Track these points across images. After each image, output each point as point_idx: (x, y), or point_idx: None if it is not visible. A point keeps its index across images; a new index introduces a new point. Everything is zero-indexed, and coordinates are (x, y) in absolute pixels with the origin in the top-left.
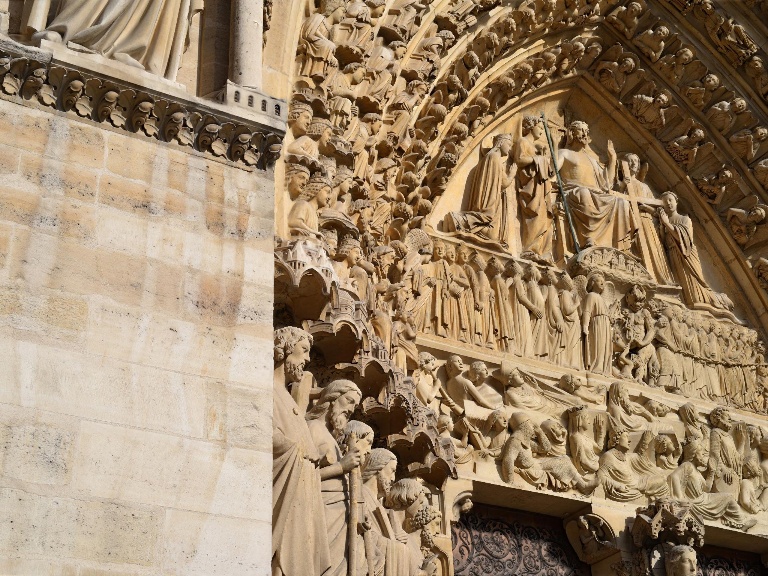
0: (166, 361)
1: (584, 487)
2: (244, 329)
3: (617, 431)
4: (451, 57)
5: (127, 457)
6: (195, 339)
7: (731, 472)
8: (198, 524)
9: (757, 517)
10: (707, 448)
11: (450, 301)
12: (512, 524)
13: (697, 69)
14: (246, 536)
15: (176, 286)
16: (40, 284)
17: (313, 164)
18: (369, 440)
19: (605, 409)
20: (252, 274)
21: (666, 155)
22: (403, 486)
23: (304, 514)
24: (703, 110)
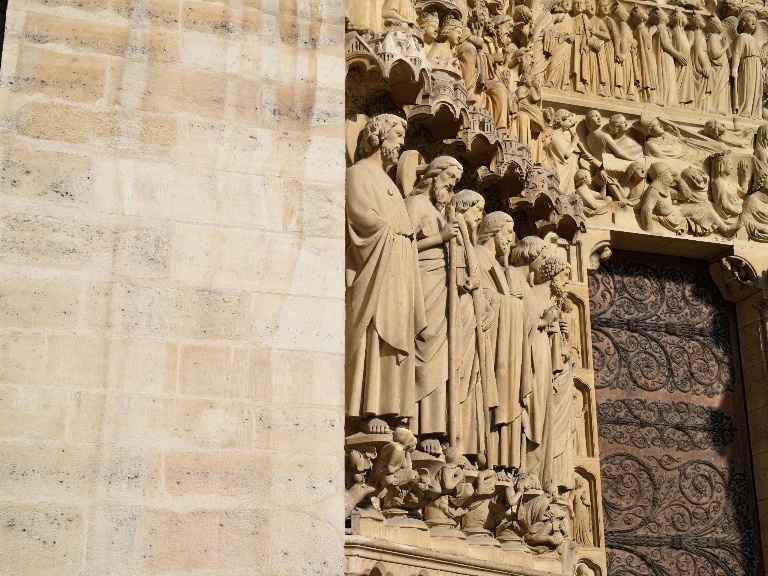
0: (248, 166)
1: (726, 230)
2: (318, 131)
3: (761, 174)
4: None
5: (216, 251)
6: (273, 144)
7: None
8: (280, 304)
9: None
10: None
11: (590, 56)
12: (655, 268)
13: None
14: (322, 312)
15: (254, 97)
16: (134, 108)
17: None
18: (479, 207)
19: (752, 152)
20: (324, 79)
21: None
22: (526, 244)
23: (397, 284)
24: None
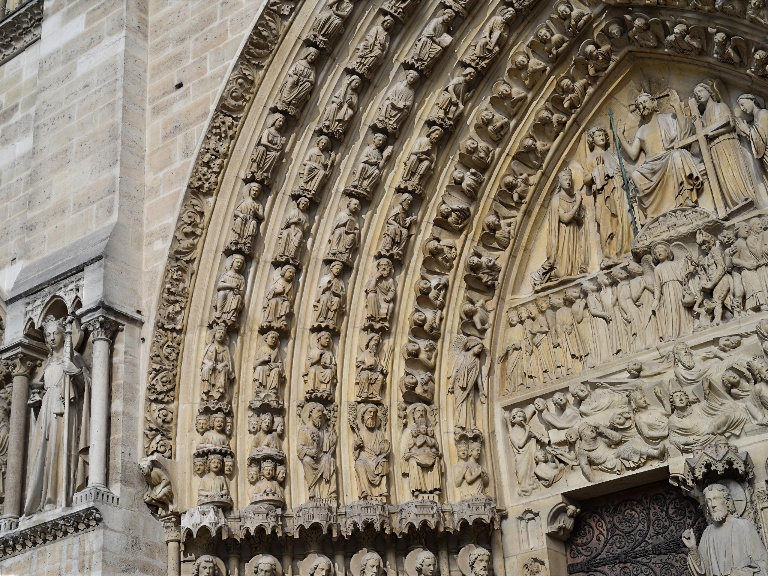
0: None
1: (657, 456)
2: None
3: None
4: (443, 188)
5: None
6: None
7: None
8: None
9: None
10: None
11: None
12: (641, 498)
13: None
14: None
15: None
16: None
17: (204, 452)
18: (321, 568)
19: None
20: None
21: (723, 65)
22: None
23: None
24: None
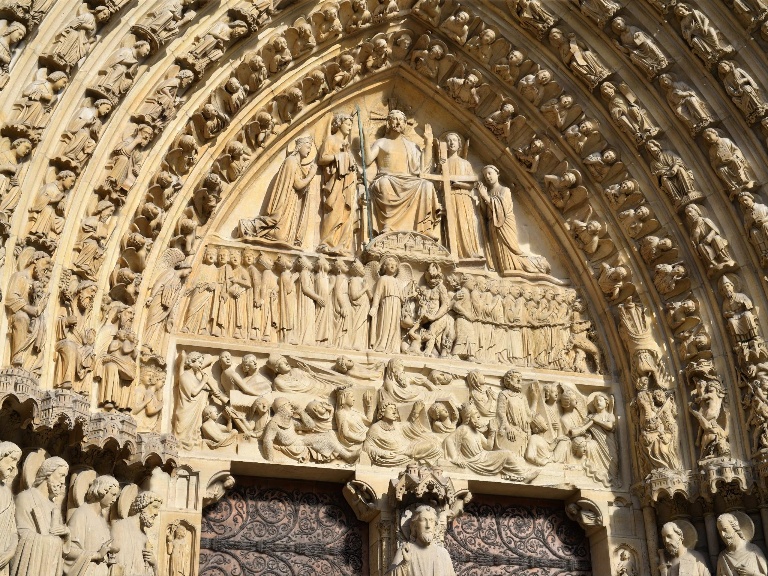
0: None
1: (347, 457)
2: None
3: (383, 405)
4: (211, 87)
5: None
6: None
7: (516, 430)
8: None
9: (545, 469)
10: (493, 409)
11: (230, 302)
12: (291, 492)
13: (504, 46)
14: None
15: None
16: None
17: None
18: (13, 457)
19: (381, 384)
20: None
21: (486, 130)
22: (97, 482)
23: None
24: (515, 84)
